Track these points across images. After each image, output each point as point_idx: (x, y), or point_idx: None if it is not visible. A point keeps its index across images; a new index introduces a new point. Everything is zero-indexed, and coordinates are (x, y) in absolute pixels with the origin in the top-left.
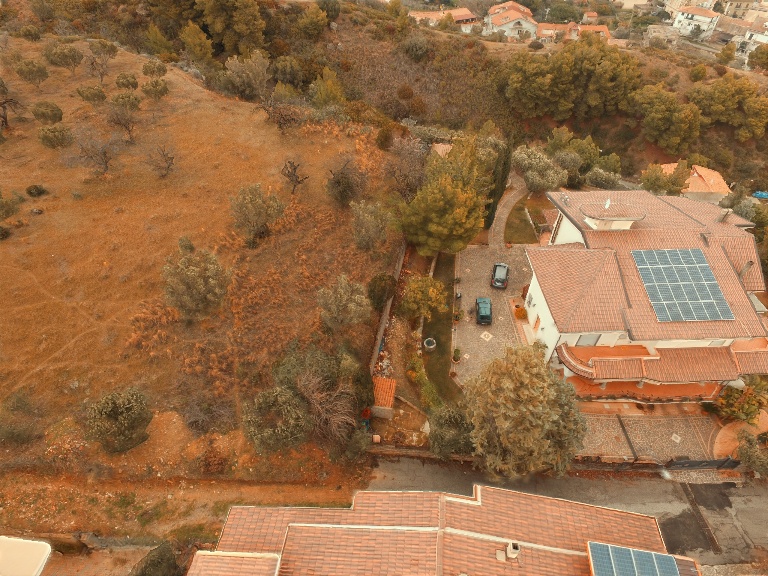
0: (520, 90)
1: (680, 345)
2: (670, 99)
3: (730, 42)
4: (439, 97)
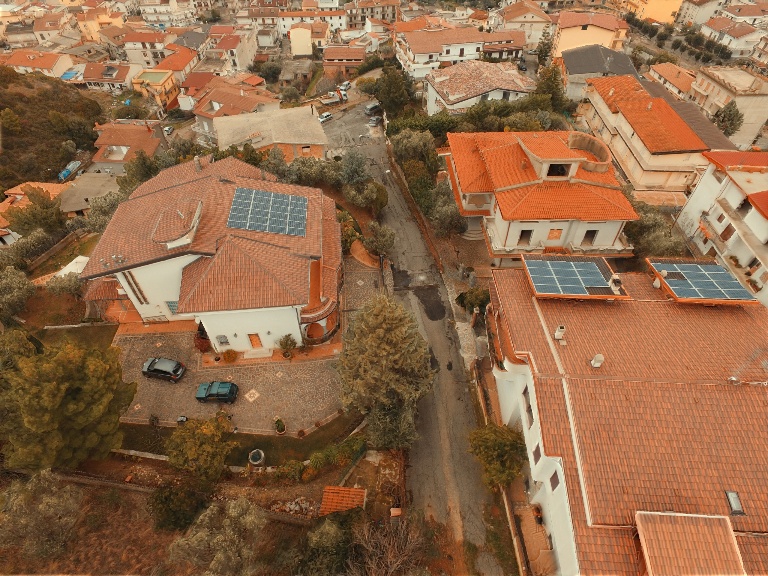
0: None
1: None
2: None
3: None
4: None
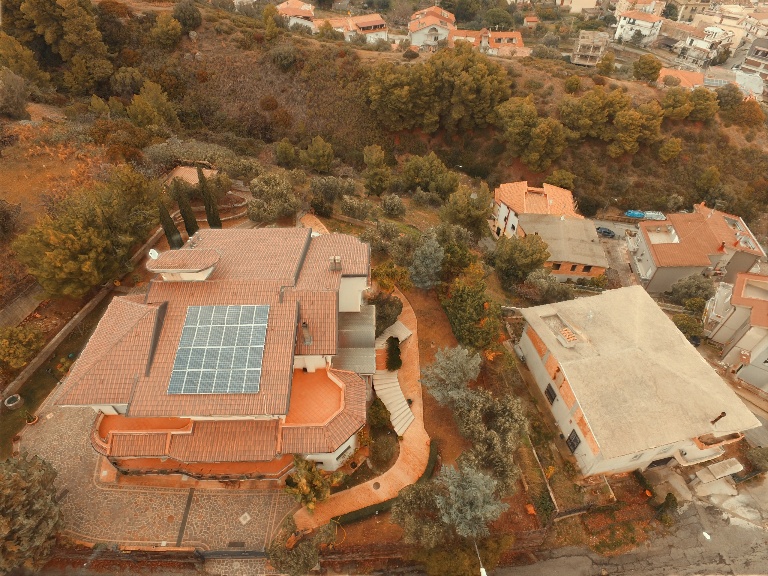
0: (381, 102)
1: (219, 418)
2: (528, 113)
3: (674, 48)
4: (306, 108)
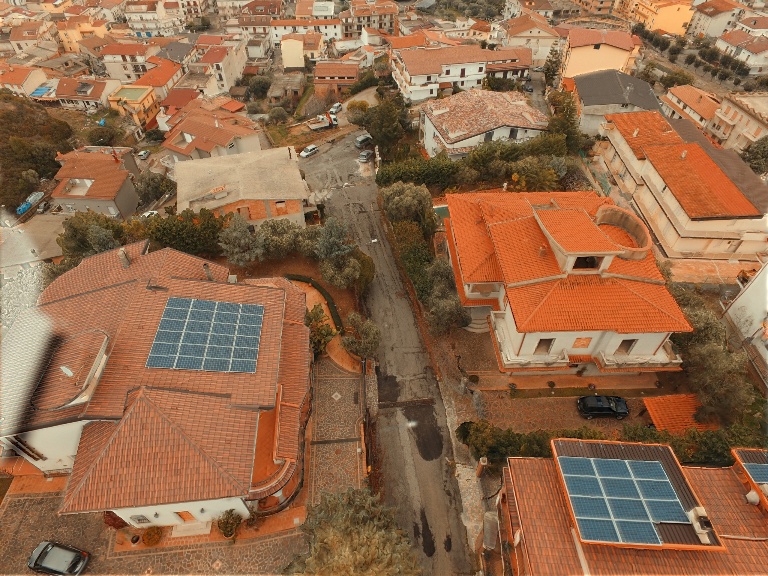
0: None
1: None
2: None
3: None
4: None
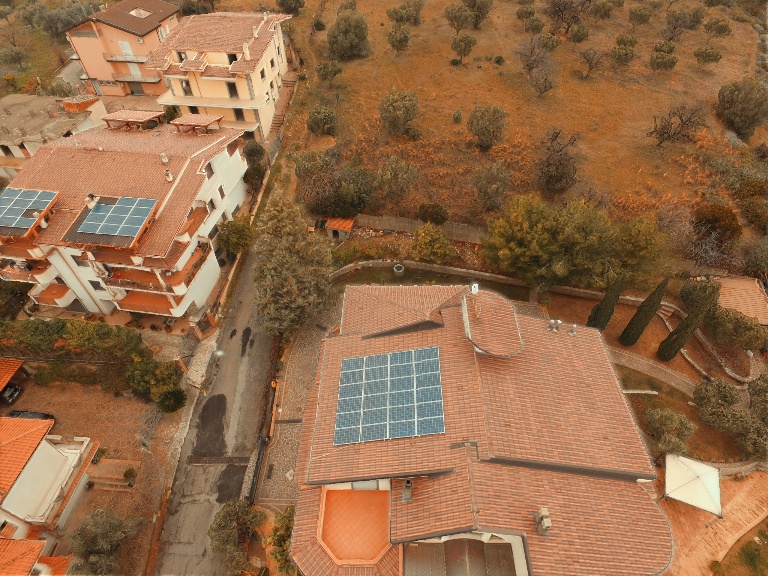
0: None
1: None
2: None
3: None
4: None
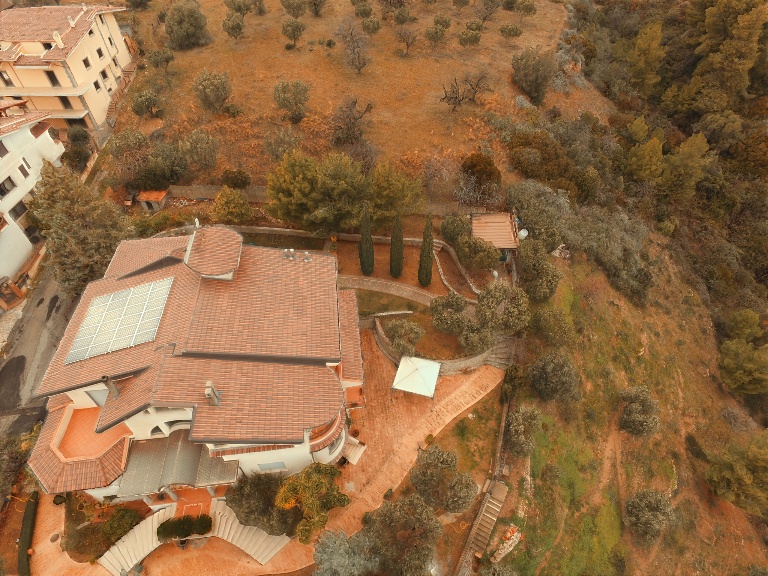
0: None
1: None
2: None
3: None
4: None
